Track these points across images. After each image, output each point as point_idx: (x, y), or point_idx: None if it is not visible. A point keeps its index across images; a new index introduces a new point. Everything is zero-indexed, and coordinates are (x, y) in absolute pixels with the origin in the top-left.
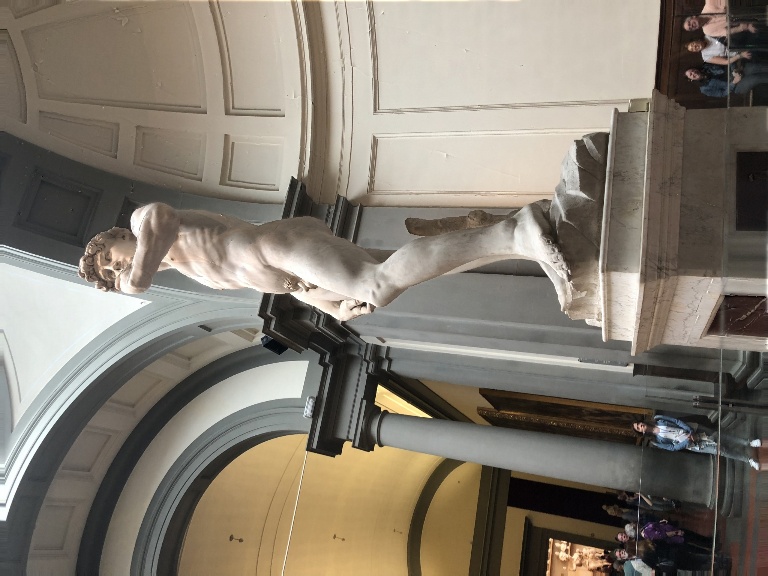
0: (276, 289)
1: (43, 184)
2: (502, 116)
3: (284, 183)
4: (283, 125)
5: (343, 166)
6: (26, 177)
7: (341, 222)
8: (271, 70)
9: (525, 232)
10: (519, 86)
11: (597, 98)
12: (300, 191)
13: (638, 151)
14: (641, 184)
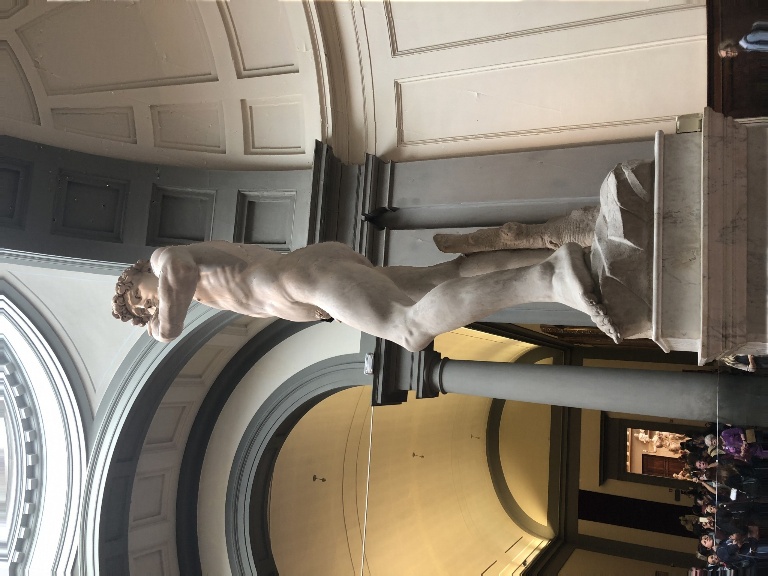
0: (308, 319)
1: (70, 185)
2: (534, 43)
3: (309, 145)
4: (299, 81)
5: (368, 119)
6: (52, 182)
7: (374, 183)
8: (277, 23)
9: (564, 284)
10: (551, 4)
11: (642, 8)
12: (327, 154)
13: (691, 184)
14: (697, 227)
